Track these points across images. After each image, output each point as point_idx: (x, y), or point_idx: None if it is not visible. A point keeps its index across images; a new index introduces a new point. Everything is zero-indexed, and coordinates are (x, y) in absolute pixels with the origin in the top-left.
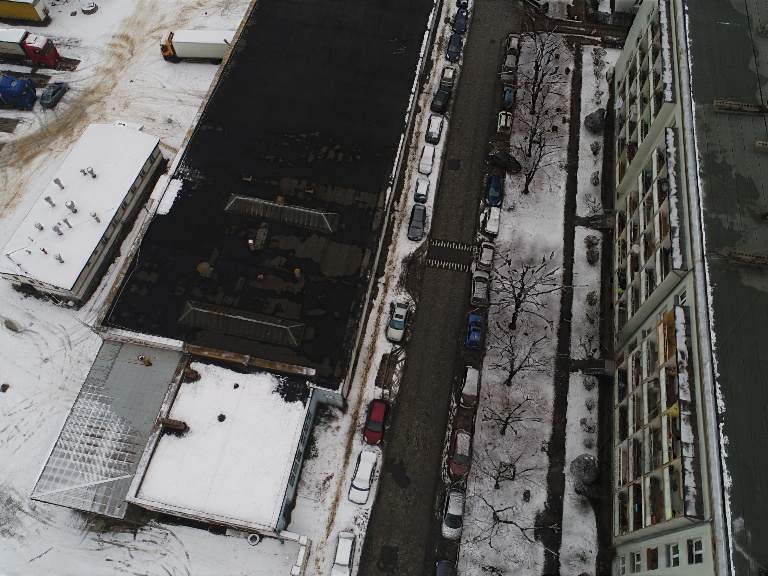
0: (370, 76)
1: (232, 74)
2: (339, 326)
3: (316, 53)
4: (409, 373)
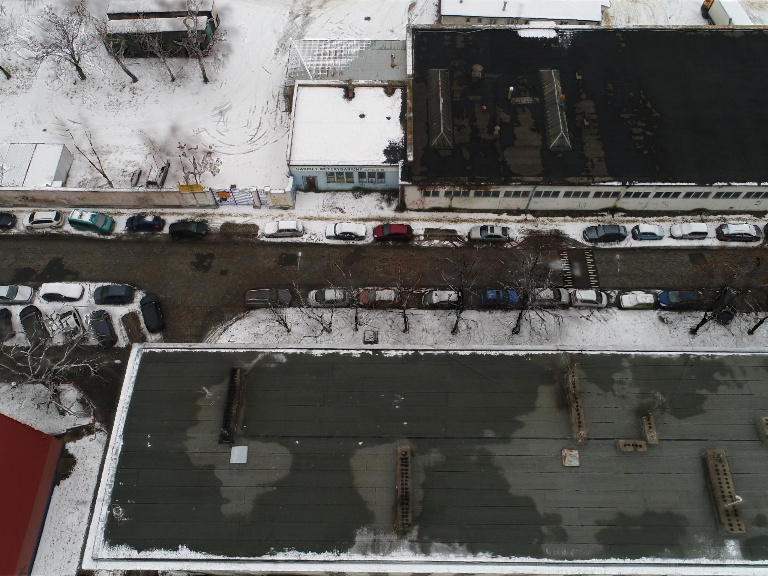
0: (760, 142)
1: (693, 36)
2: (458, 171)
3: (763, 91)
4: (443, 252)
